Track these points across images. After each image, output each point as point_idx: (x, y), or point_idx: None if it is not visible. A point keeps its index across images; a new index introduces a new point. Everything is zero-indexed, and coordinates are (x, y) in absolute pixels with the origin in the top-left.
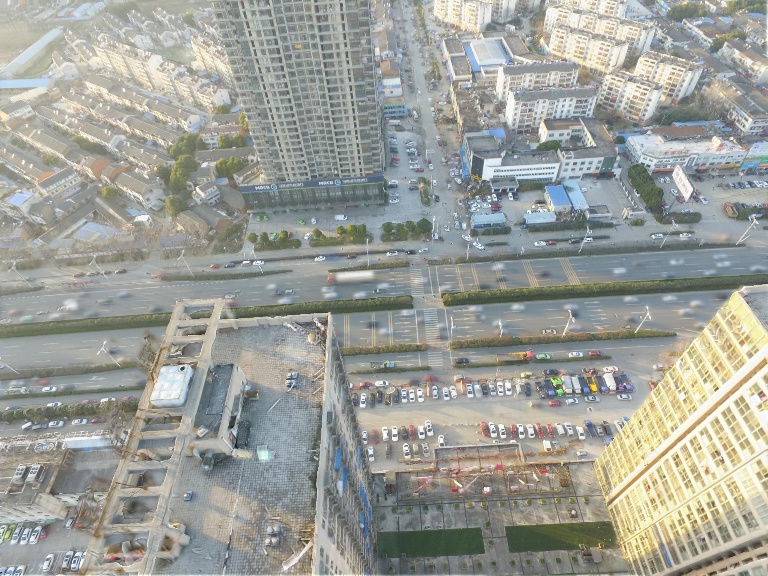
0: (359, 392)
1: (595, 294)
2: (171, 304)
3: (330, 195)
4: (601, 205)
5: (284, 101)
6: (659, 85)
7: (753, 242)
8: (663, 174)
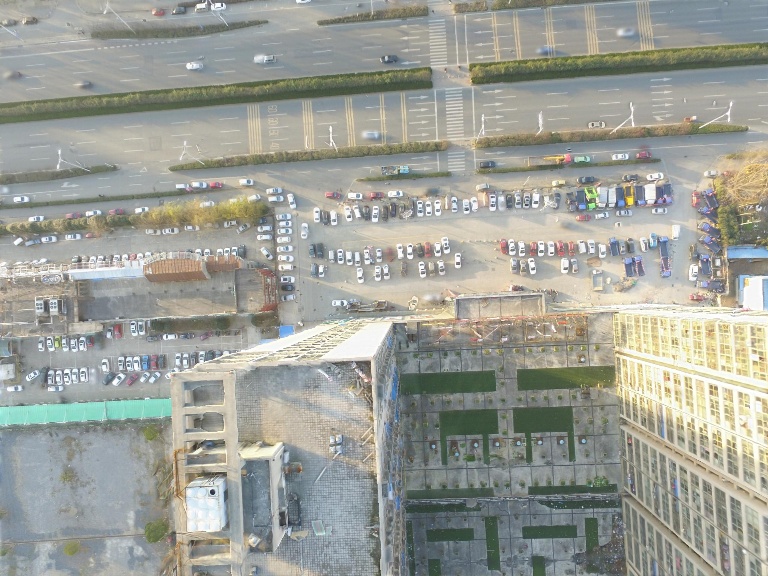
0: (370, 204)
1: (669, 67)
2: (119, 78)
3: None
4: None
5: None
6: None
7: None
8: None
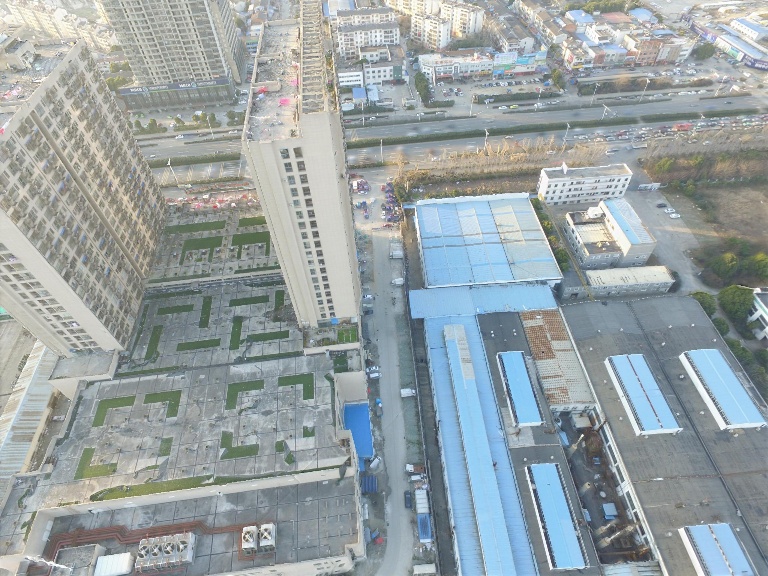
0: None
1: (365, 145)
2: None
3: (191, 97)
4: (388, 98)
5: (140, 16)
6: (445, 20)
7: (482, 115)
8: (441, 80)
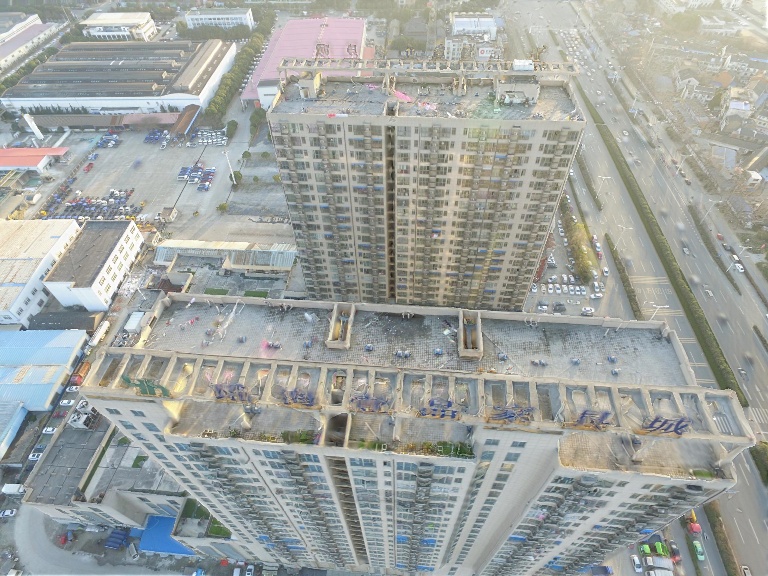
0: None
1: None
2: (664, 216)
3: None
4: None
5: None
6: None
7: None
8: None
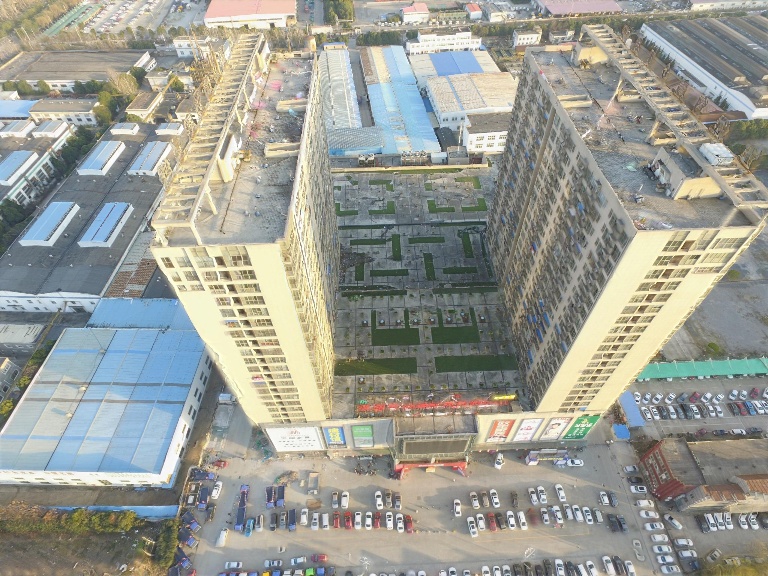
0: None
1: None
2: None
3: None
4: None
5: None
6: None
7: None
8: None
